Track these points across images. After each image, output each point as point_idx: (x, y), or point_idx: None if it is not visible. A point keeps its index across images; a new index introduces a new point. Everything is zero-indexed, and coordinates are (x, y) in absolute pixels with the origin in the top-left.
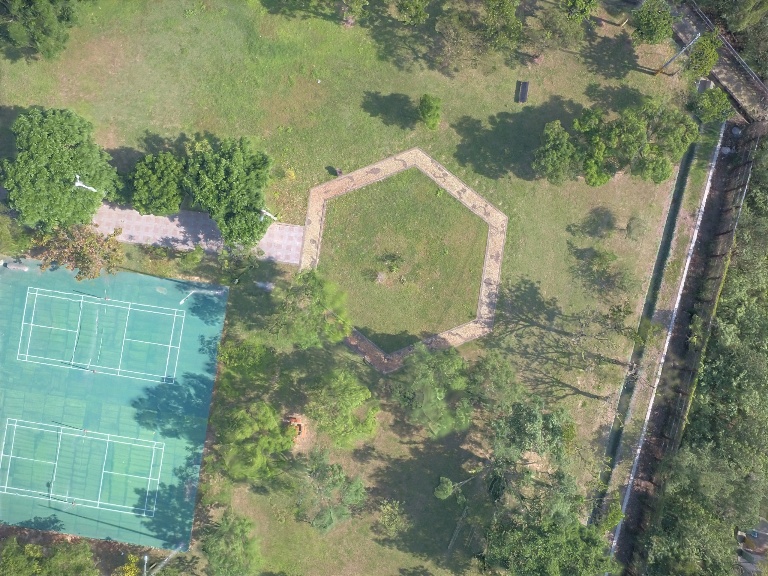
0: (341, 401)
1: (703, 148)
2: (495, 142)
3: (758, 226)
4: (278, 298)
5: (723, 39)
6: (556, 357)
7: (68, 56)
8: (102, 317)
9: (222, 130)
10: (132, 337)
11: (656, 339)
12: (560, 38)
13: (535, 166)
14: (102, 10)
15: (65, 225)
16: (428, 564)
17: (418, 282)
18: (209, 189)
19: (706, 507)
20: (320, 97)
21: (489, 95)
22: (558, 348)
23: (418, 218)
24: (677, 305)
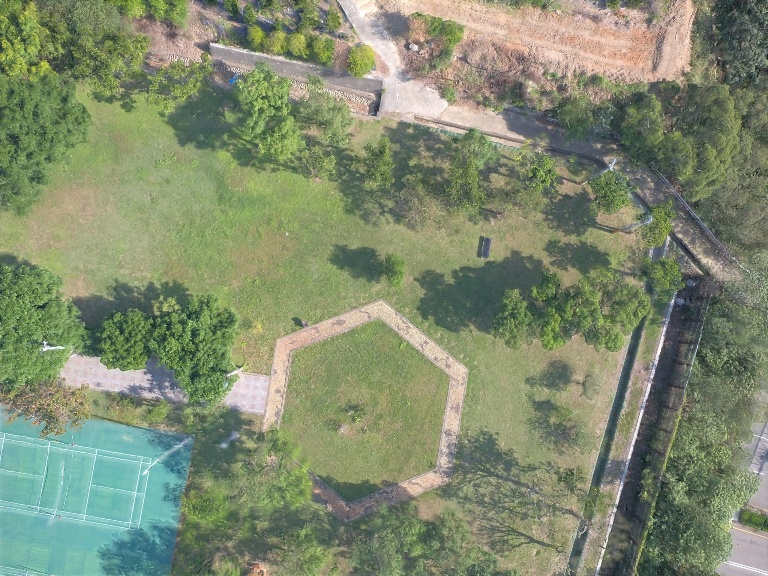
0: (300, 573)
1: (658, 304)
2: (457, 296)
3: (707, 386)
4: (243, 446)
5: (679, 197)
6: (512, 507)
7: (39, 203)
8: (69, 463)
9: (191, 280)
10: (98, 483)
11: (609, 489)
12: (520, 210)
13: (494, 332)
14: (74, 158)
15: (32, 381)
16: None
17: (380, 432)
18: (175, 350)
19: None
20: (288, 249)
21: (453, 250)
22: (515, 498)
23: (381, 369)
24: (630, 456)
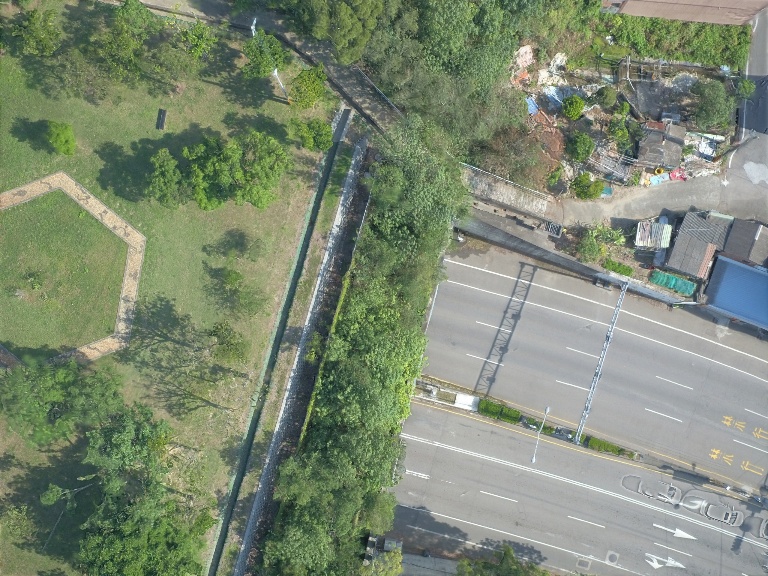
0: None
1: (337, 174)
2: (136, 167)
3: (372, 248)
4: None
5: (360, 71)
6: None
7: None
8: None
9: None
10: None
11: (287, 354)
12: (168, 71)
13: (147, 191)
14: None
15: None
16: (65, 567)
17: (59, 299)
18: None
19: (314, 514)
20: None
21: (132, 122)
22: (191, 362)
23: (61, 238)
24: (307, 322)
